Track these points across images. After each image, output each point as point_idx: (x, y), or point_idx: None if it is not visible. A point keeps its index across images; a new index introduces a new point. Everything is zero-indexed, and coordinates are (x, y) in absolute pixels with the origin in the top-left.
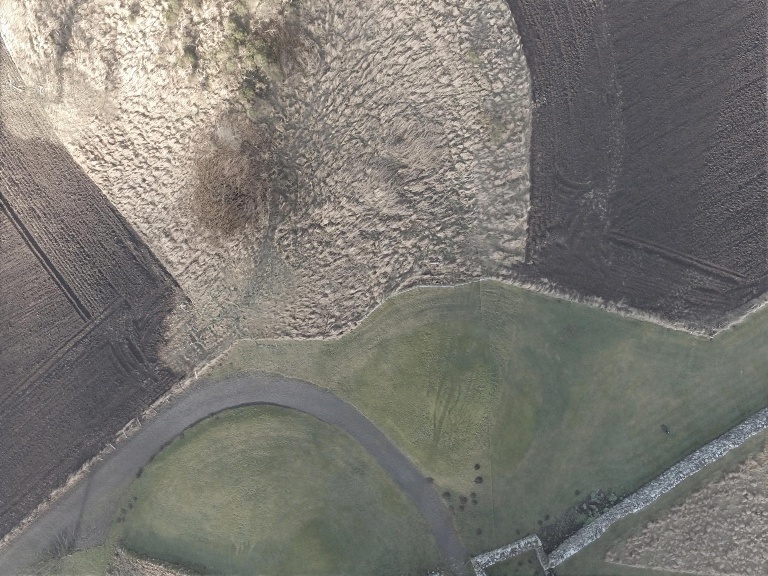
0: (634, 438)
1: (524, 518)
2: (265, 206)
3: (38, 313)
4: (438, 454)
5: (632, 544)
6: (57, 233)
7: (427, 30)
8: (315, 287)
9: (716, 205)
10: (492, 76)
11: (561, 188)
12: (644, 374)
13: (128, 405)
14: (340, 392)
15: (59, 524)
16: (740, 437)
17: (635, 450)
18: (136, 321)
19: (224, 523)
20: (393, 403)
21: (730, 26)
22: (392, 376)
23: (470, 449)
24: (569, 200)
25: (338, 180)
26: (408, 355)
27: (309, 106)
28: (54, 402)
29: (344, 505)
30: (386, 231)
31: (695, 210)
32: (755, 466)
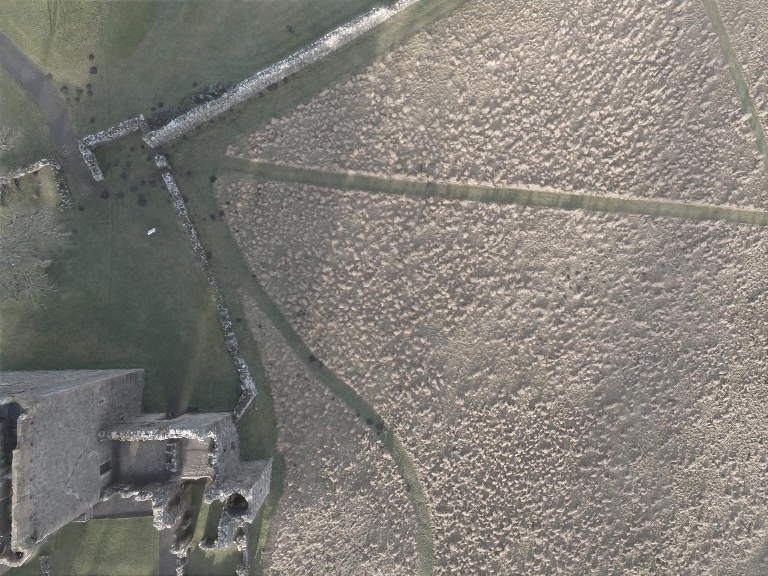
0: (259, 38)
1: (137, 105)
2: None
3: None
4: (54, 47)
5: (255, 139)
6: None
7: None
8: None
9: None
10: None
11: None
12: None
13: None
14: None
15: None
16: (350, 21)
17: (259, 49)
18: None
19: None
20: (13, 3)
21: None
22: None
23: (84, 39)
24: None
25: None
26: None
27: None
28: None
29: None
30: None
31: None
32: (384, 69)
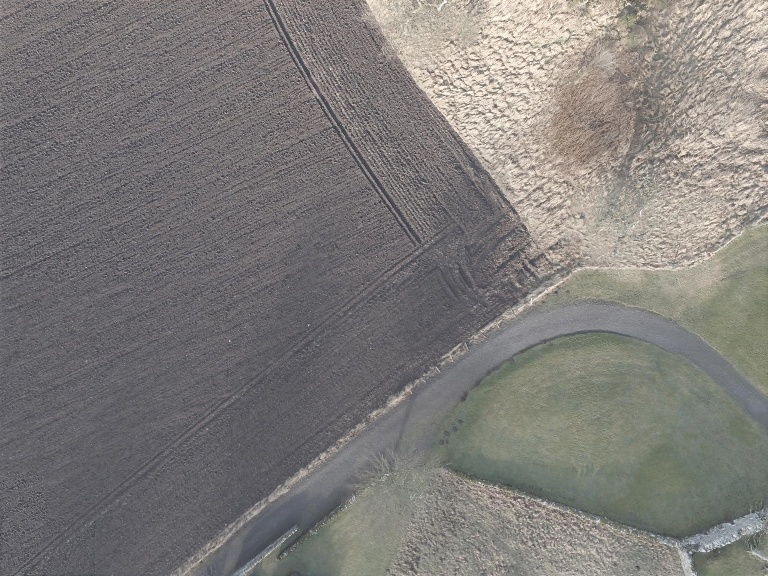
0: None
1: None
2: (626, 134)
3: (366, 235)
4: None
5: None
6: (392, 157)
7: None
8: (667, 217)
9: None
10: None
11: None
12: None
13: (455, 329)
14: (685, 322)
15: (377, 444)
16: None
17: None
18: (468, 247)
19: (563, 446)
20: (747, 334)
21: None
22: (747, 307)
23: None
24: None
25: (700, 112)
26: (767, 286)
27: (680, 37)
28: (378, 324)
29: (691, 433)
30: (746, 164)
31: None
32: None
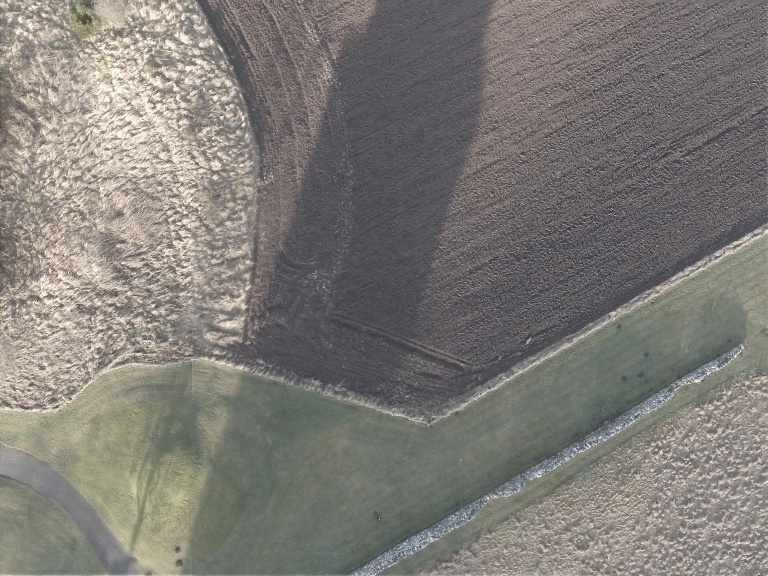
0: (345, 524)
1: None
2: None
3: None
4: (141, 535)
5: None
6: None
7: (145, 105)
8: (34, 359)
9: (444, 289)
10: (211, 154)
11: (284, 268)
12: (360, 459)
13: None
14: (57, 465)
15: None
16: (441, 530)
17: (345, 537)
18: None
19: None
20: (102, 480)
21: (469, 107)
22: (102, 453)
23: (171, 531)
24: (292, 280)
25: (56, 253)
26: (116, 433)
27: (25, 178)
28: None
29: None
30: (102, 306)
31: (423, 294)
32: (470, 556)
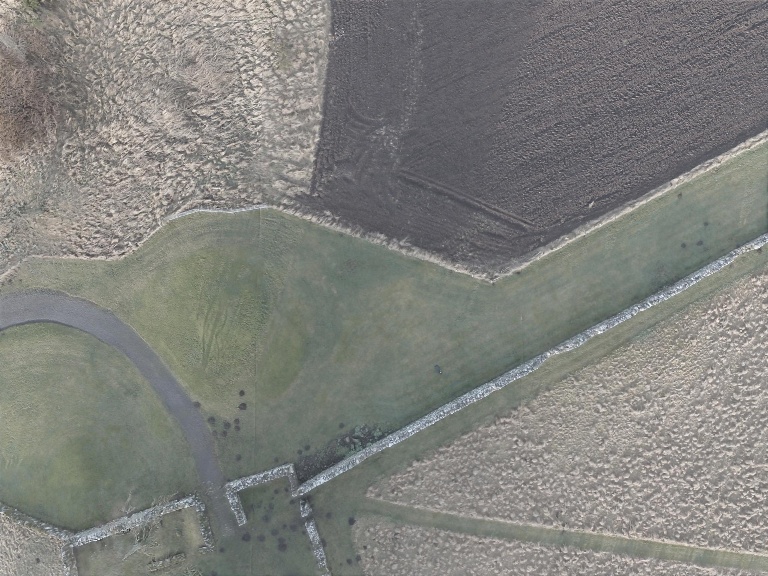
0: (406, 376)
1: (284, 447)
2: (52, 120)
3: None
4: (205, 378)
5: (395, 481)
6: None
7: None
8: (101, 206)
9: (510, 151)
10: (285, 3)
11: (353, 122)
12: (422, 314)
13: None
14: (121, 313)
15: None
16: (504, 379)
17: (406, 388)
18: None
19: None
20: (167, 326)
21: None
22: (168, 299)
23: (236, 375)
24: (360, 135)
25: (127, 99)
26: (183, 278)
27: (99, 21)
28: None
29: (114, 425)
30: (172, 153)
31: (488, 154)
32: (528, 413)
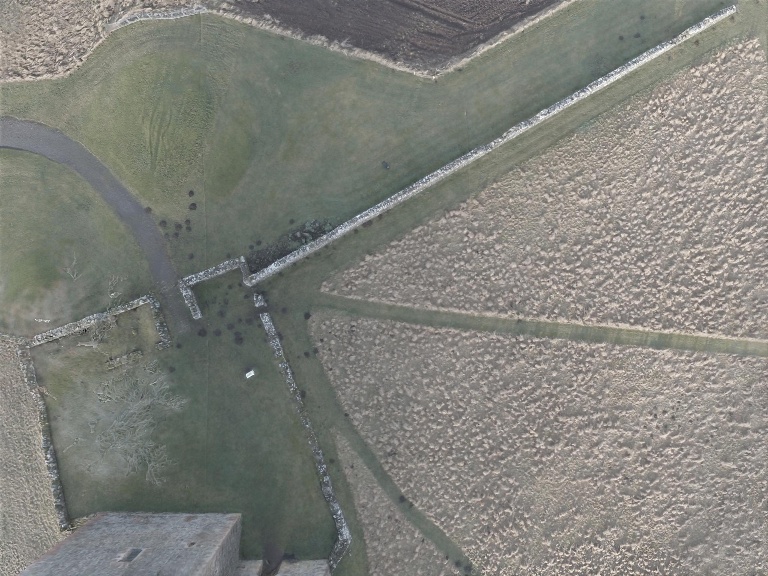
0: (354, 173)
1: (236, 243)
2: None
3: None
4: (154, 182)
5: (349, 276)
6: None
7: None
8: (44, 25)
9: None
10: None
11: None
12: (367, 113)
13: None
14: (69, 131)
15: None
16: (449, 164)
17: (355, 185)
18: None
19: None
20: (114, 135)
21: None
22: (114, 108)
23: (184, 175)
24: None
25: None
26: (127, 85)
27: None
28: None
29: (67, 238)
30: None
31: None
32: (477, 206)
